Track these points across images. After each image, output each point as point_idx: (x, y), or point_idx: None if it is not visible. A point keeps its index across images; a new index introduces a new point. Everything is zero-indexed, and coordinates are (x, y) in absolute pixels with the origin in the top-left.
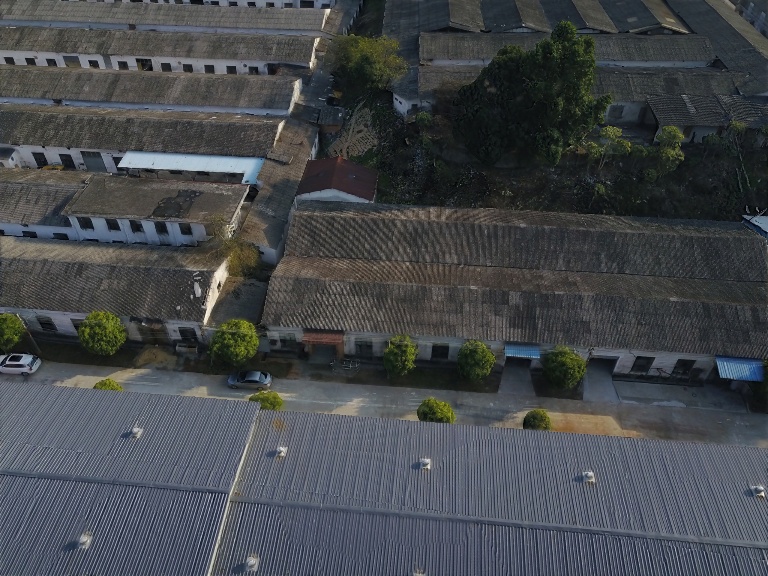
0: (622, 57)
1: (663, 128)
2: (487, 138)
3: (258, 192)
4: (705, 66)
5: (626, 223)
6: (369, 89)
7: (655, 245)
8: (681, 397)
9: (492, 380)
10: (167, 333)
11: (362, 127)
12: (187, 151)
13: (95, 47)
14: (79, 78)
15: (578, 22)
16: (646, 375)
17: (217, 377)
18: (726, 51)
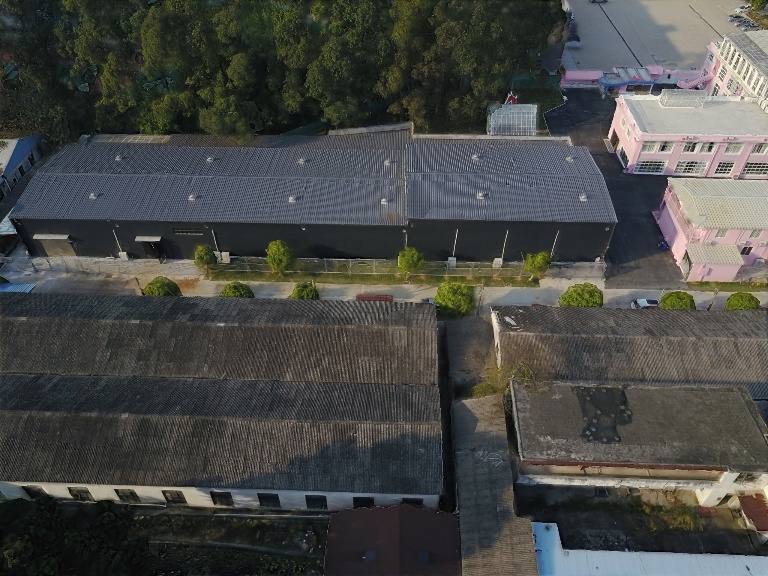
0: None
1: None
2: None
3: None
4: None
5: None
6: None
7: None
8: None
9: None
10: None
11: None
12: None
13: None
14: None
15: None
16: None
17: None
18: None
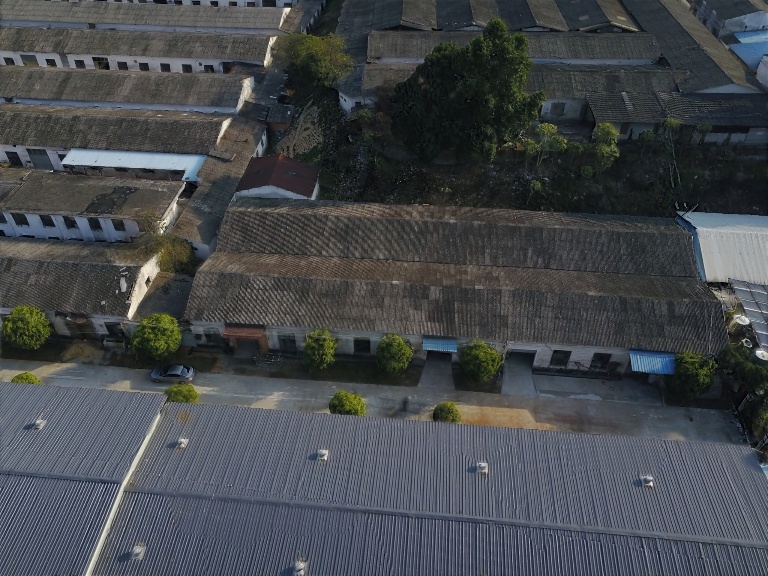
0: (568, 55)
1: (597, 125)
2: (422, 135)
3: (197, 189)
4: (651, 64)
5: (557, 219)
6: (316, 87)
7: (582, 240)
8: (598, 390)
9: (413, 374)
10: (94, 328)
11: (309, 125)
12: (131, 148)
13: (52, 46)
14: (31, 76)
15: (529, 20)
16: (565, 369)
17: (142, 371)
18: (671, 49)
